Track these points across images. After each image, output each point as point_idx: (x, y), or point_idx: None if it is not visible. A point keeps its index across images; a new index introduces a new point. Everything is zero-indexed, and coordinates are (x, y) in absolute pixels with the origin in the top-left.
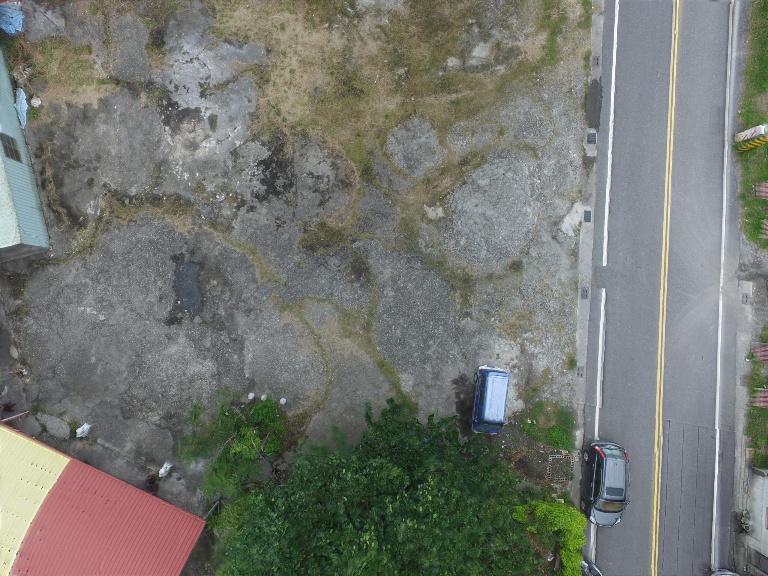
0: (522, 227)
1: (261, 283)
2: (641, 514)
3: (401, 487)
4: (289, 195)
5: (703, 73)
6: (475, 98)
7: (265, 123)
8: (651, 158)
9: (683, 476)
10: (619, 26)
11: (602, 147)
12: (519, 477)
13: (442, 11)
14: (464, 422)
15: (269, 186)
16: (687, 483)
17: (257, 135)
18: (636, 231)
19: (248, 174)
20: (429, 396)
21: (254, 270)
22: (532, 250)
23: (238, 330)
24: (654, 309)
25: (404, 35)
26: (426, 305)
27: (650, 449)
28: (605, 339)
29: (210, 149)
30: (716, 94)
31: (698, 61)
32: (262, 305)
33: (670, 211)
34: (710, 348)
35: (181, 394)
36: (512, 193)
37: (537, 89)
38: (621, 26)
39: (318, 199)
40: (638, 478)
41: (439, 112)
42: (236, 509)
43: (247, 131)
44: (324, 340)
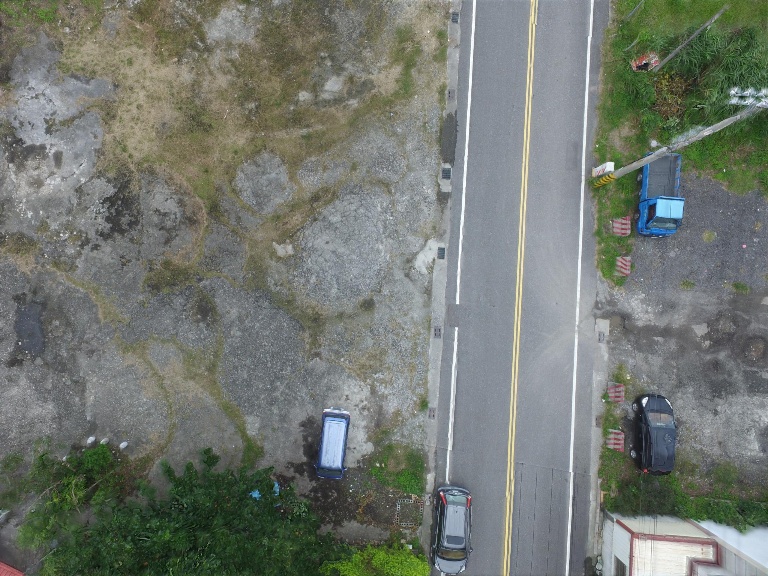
0: (374, 265)
1: (104, 323)
2: (492, 560)
3: (183, 550)
4: (135, 233)
5: (560, 107)
6: (327, 133)
7: (111, 159)
8: (506, 194)
9: (536, 521)
10: (475, 59)
11: (457, 182)
12: (367, 522)
13: (294, 45)
14: (312, 465)
15: (114, 224)
16: (540, 528)
17: (103, 172)
18: (490, 268)
19: (93, 212)
20: (275, 439)
21: (97, 310)
22: (384, 288)
23: (80, 372)
24: (508, 348)
25: (255, 69)
26: (274, 345)
27: (502, 493)
28: (457, 379)
29: (54, 186)
30: (573, 128)
31: (555, 94)
32: (105, 346)
33: (524, 248)
34: (565, 388)
35: (20, 438)
36: (364, 230)
37: (390, 124)
38: (477, 59)
39: (165, 237)
40: (489, 523)
41: (290, 147)
42: (54, 562)
43: (93, 168)
44: (168, 382)
